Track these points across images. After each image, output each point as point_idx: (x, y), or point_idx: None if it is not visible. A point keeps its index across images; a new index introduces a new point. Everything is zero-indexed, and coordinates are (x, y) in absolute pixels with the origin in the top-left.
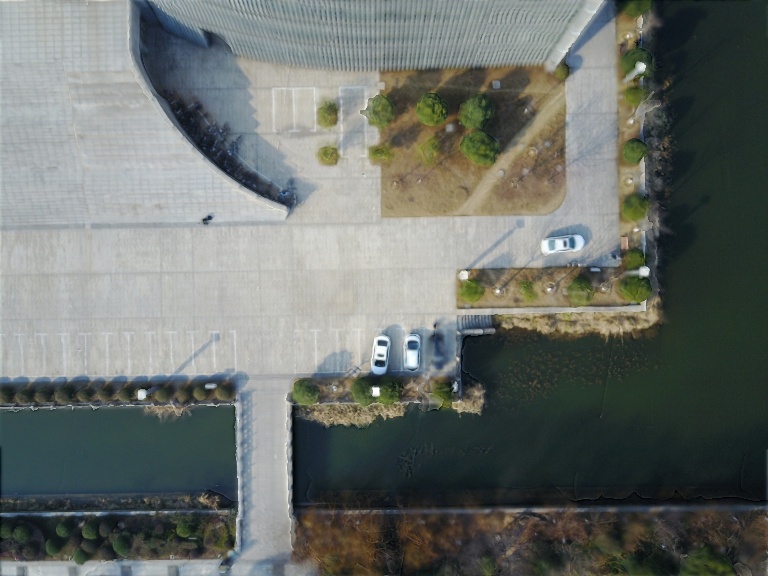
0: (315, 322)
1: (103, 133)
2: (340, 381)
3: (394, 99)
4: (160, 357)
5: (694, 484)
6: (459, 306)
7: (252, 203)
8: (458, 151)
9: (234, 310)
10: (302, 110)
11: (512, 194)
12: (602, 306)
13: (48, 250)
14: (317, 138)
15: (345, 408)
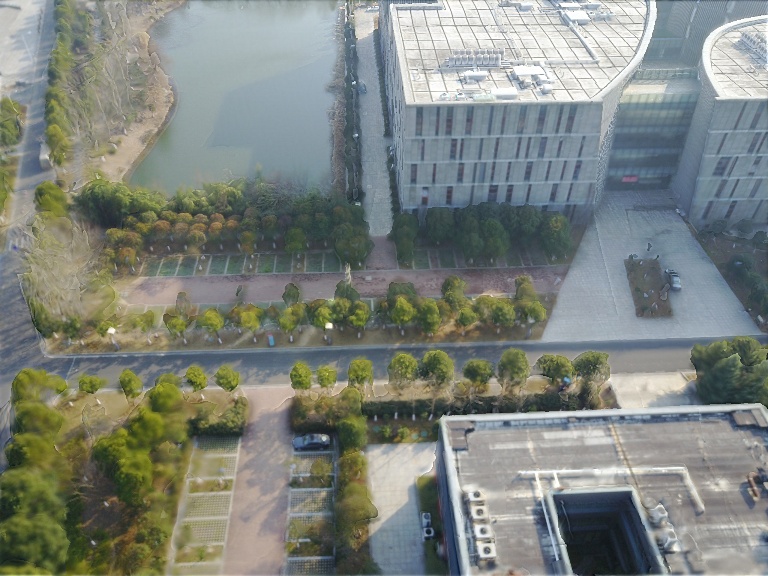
0: None
1: None
2: None
3: None
4: None
5: (321, 7)
6: None
7: None
8: None
9: None
10: None
11: None
12: (361, 3)
13: None
14: None
15: None
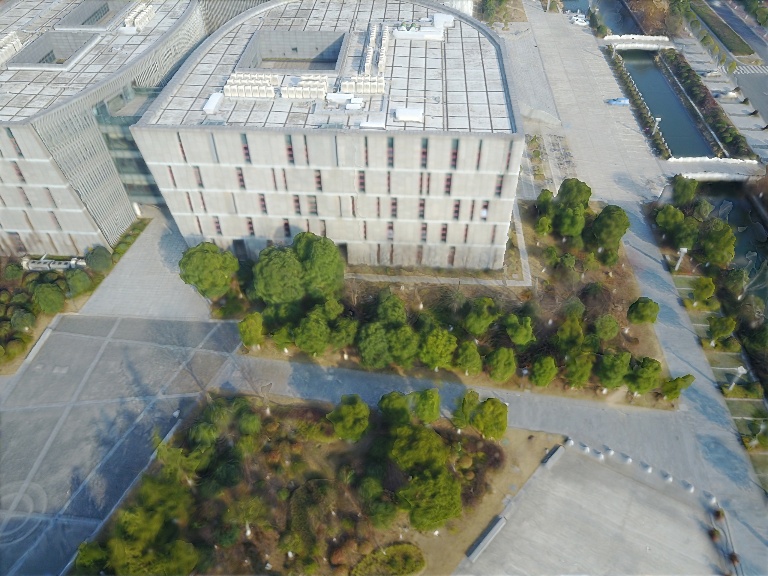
0: None
1: None
2: None
3: None
4: None
5: None
6: (558, 12)
7: None
8: None
9: None
10: None
11: (515, 4)
12: None
13: None
14: None
15: None
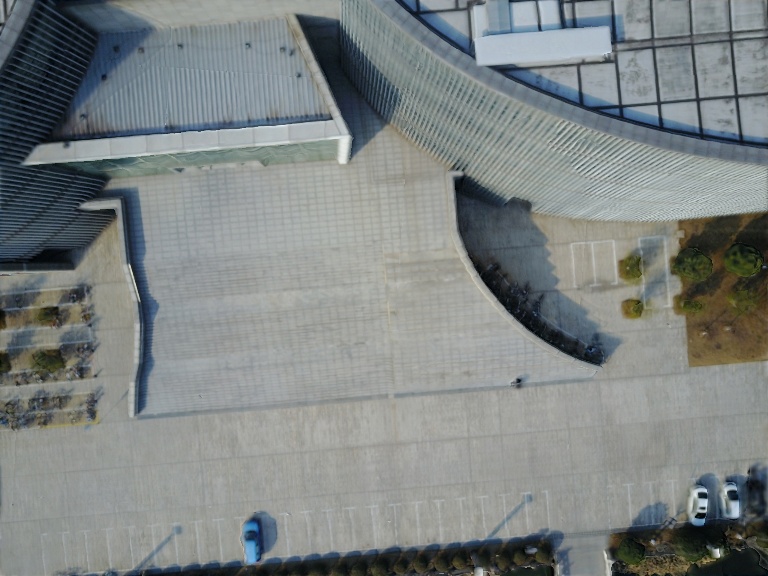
0: (628, 476)
1: (417, 309)
2: (656, 533)
3: (695, 247)
4: (472, 522)
5: None
6: None
7: (562, 364)
8: (763, 295)
9: (545, 470)
10: (602, 263)
11: None
12: None
13: (351, 423)
14: (619, 291)
15: (661, 559)
